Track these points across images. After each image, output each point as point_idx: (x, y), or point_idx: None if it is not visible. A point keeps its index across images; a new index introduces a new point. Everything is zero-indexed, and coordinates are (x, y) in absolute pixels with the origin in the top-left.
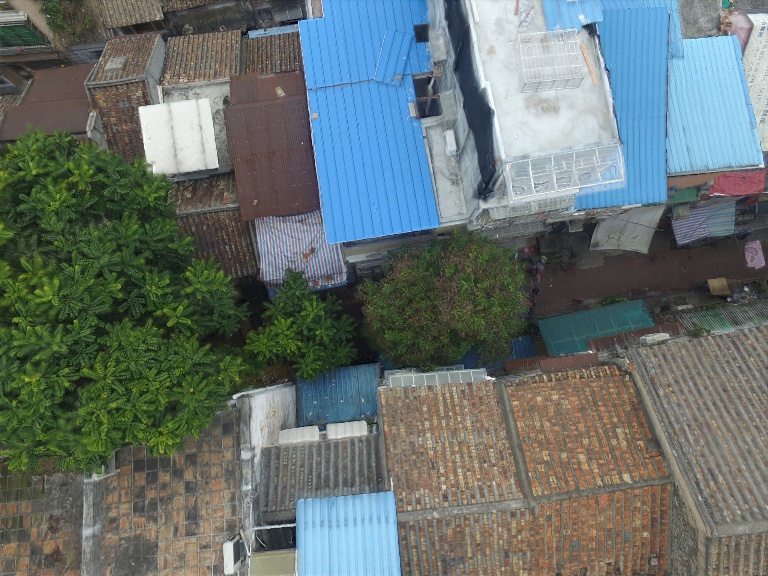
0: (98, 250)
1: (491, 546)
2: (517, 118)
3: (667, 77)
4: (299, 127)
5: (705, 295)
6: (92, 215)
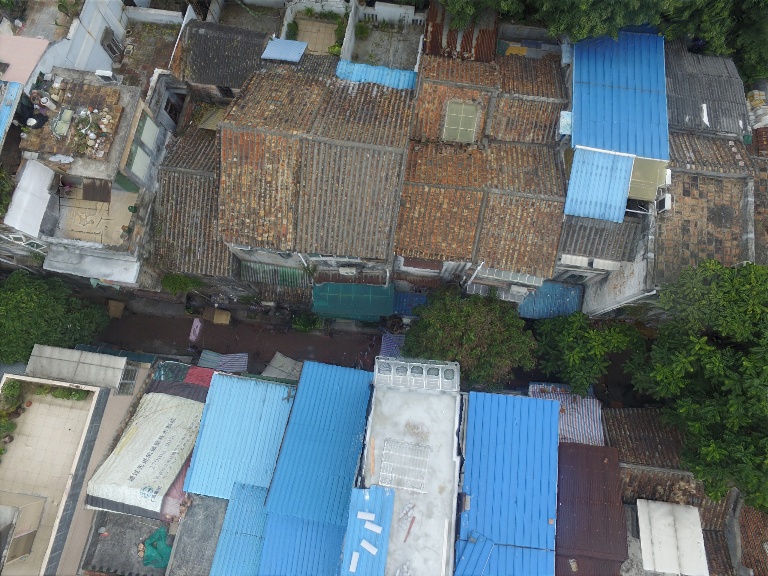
0: (761, 390)
1: (510, 175)
2: (438, 426)
3: (280, 453)
4: (562, 521)
5: (232, 314)
6: (762, 432)
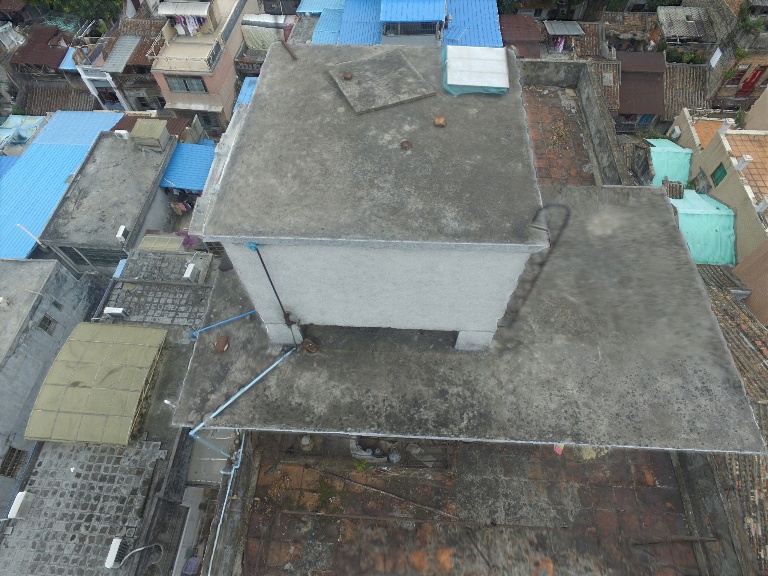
0: None
1: None
2: None
3: None
4: (504, 32)
5: None
6: None
